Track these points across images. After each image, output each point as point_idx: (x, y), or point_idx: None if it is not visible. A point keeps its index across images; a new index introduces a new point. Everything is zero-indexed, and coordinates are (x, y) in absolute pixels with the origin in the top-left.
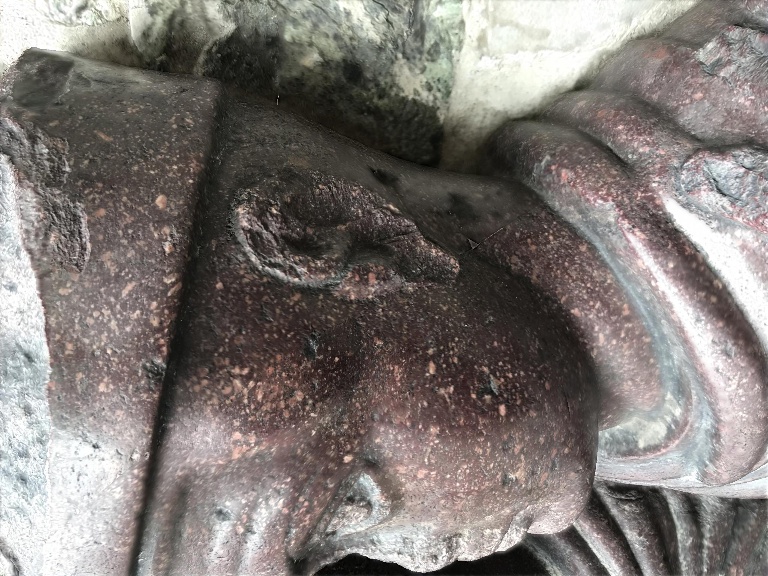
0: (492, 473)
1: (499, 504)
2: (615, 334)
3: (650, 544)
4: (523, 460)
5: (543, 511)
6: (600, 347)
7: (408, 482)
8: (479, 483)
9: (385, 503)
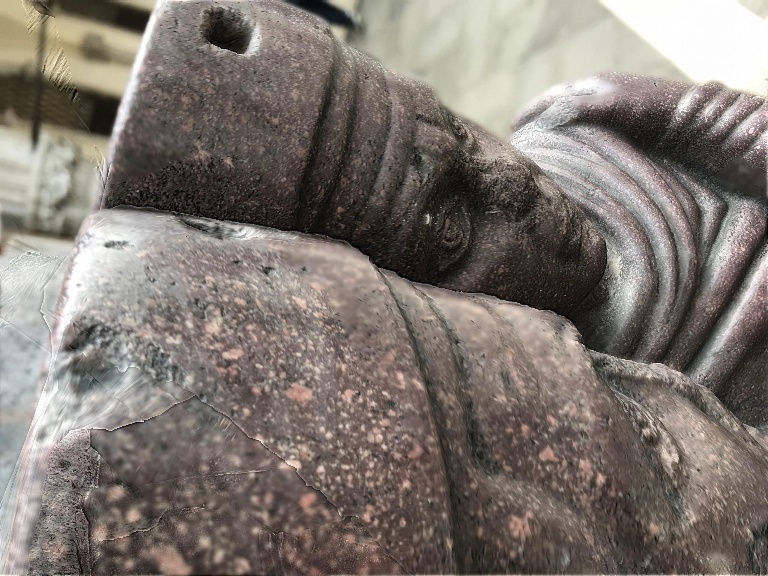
0: None
1: None
2: None
3: None
4: None
5: None
6: None
7: None
8: None
9: None
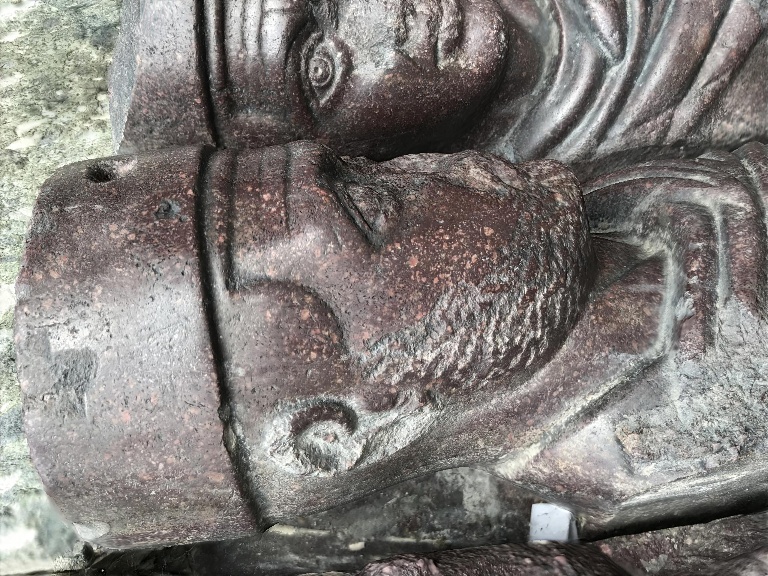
0: None
1: None
2: None
3: None
4: None
5: None
6: None
7: None
8: None
9: None
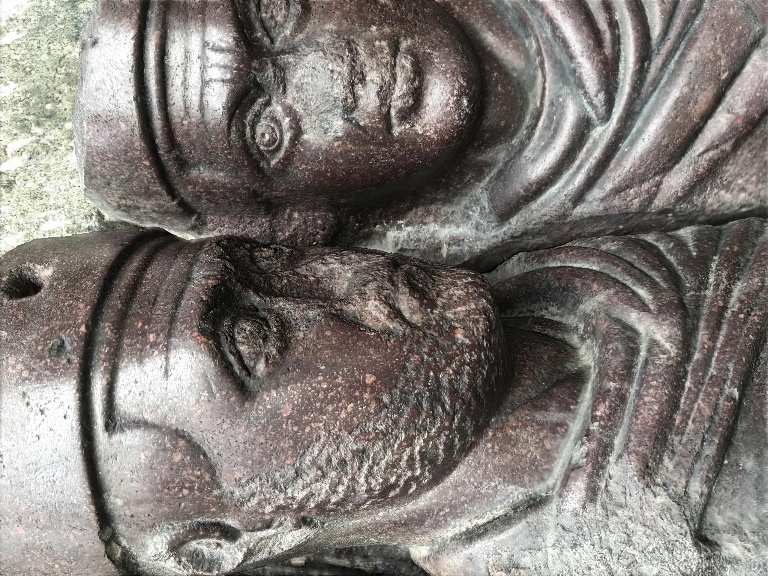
0: None
1: (378, 18)
2: (465, 4)
3: (624, 242)
4: None
5: (427, 58)
6: (458, 12)
7: None
8: None
9: (297, 0)
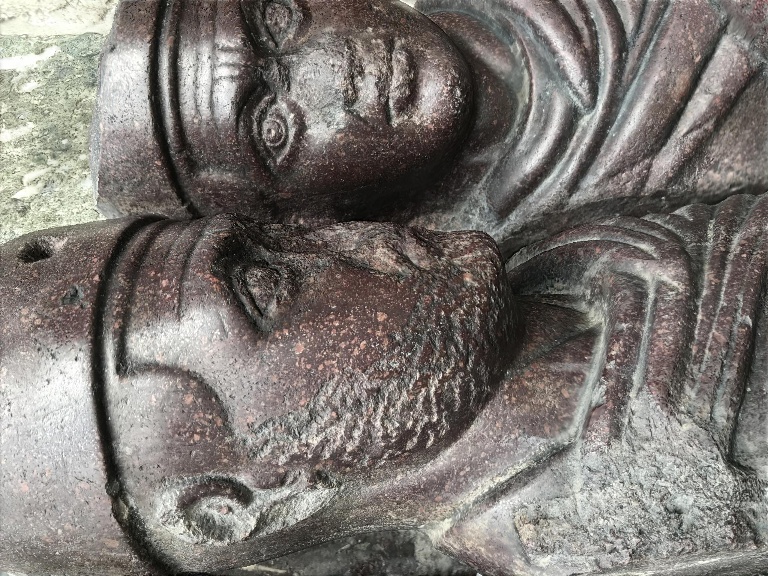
0: (360, 0)
1: (373, 22)
2: None
3: None
4: (381, 3)
5: (421, 55)
6: (447, 28)
7: (311, 2)
8: (353, 3)
9: None
